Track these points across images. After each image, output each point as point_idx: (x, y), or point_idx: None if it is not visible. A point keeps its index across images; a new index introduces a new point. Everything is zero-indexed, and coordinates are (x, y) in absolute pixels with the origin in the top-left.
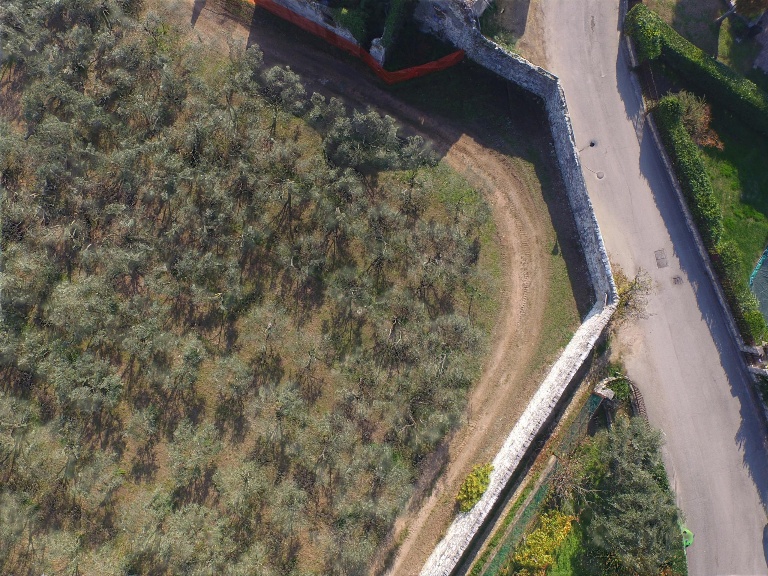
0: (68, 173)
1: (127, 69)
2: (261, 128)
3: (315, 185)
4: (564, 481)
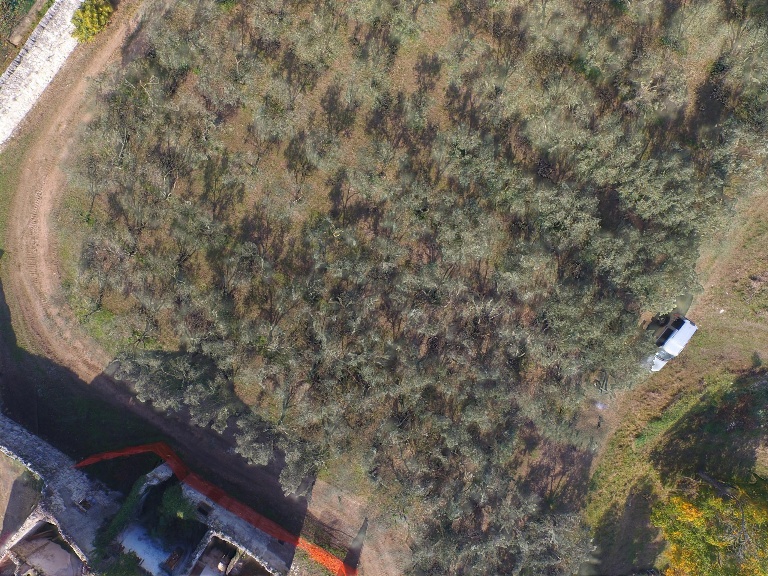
0: (474, 370)
1: (433, 480)
2: (298, 407)
3: (223, 336)
4: (4, 17)
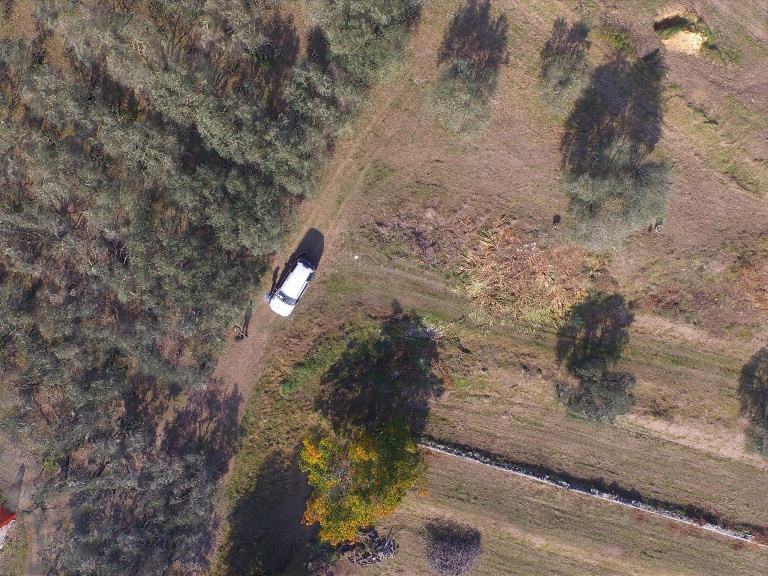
0: None
1: (82, 425)
2: None
3: None
4: None
